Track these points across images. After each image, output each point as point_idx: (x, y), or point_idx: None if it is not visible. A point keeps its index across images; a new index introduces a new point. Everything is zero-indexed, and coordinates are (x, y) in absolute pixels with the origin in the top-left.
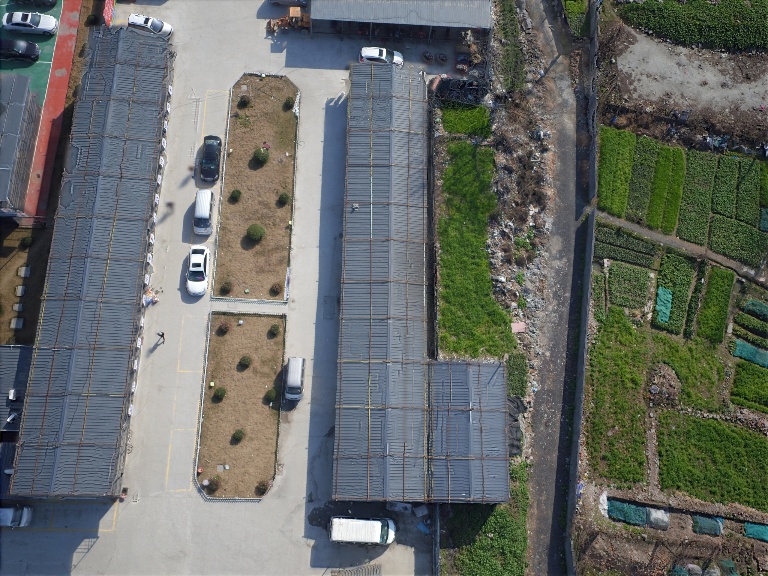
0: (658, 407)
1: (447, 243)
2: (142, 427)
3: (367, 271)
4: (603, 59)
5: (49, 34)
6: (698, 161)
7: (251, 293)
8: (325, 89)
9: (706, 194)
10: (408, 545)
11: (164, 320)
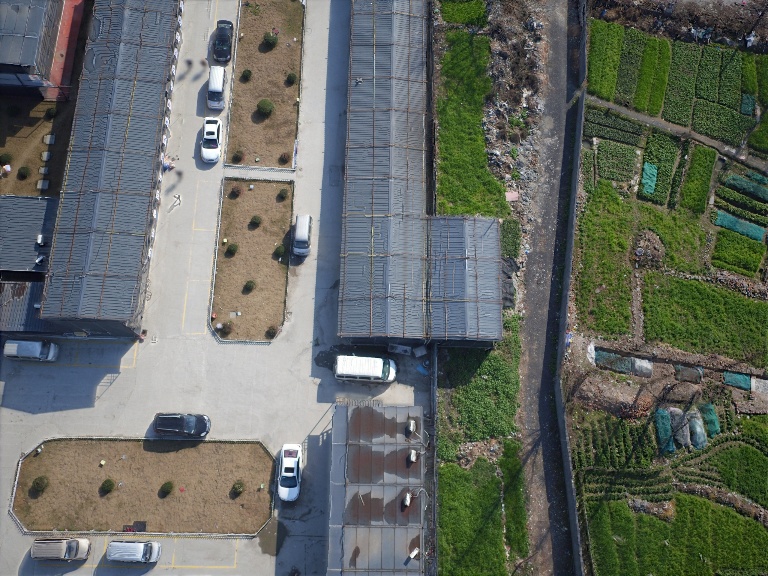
0: (643, 268)
1: (445, 120)
2: (160, 278)
3: (370, 137)
4: None
5: None
6: (683, 51)
7: (261, 162)
8: None
9: (690, 80)
10: (408, 385)
11: (180, 184)
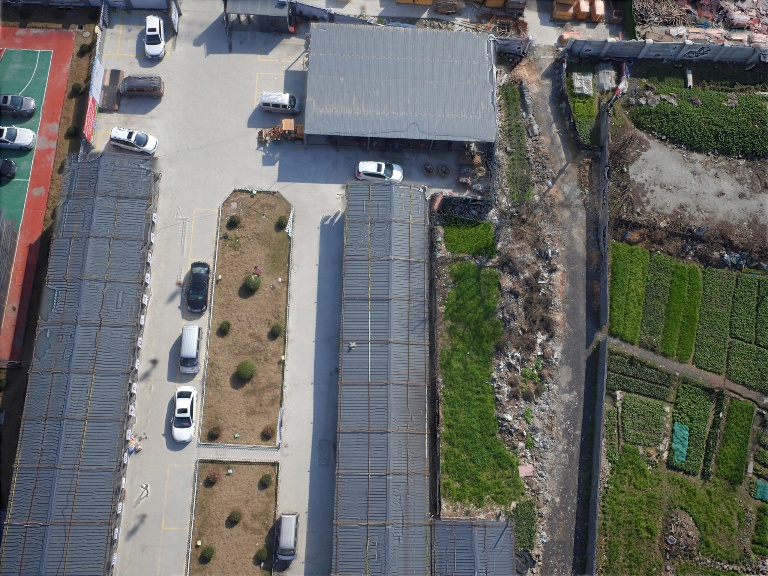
0: (675, 559)
1: (450, 377)
2: None
3: (365, 419)
4: (614, 168)
5: (26, 149)
6: (715, 280)
7: (241, 438)
8: (320, 206)
9: (724, 317)
10: None
11: (148, 470)
